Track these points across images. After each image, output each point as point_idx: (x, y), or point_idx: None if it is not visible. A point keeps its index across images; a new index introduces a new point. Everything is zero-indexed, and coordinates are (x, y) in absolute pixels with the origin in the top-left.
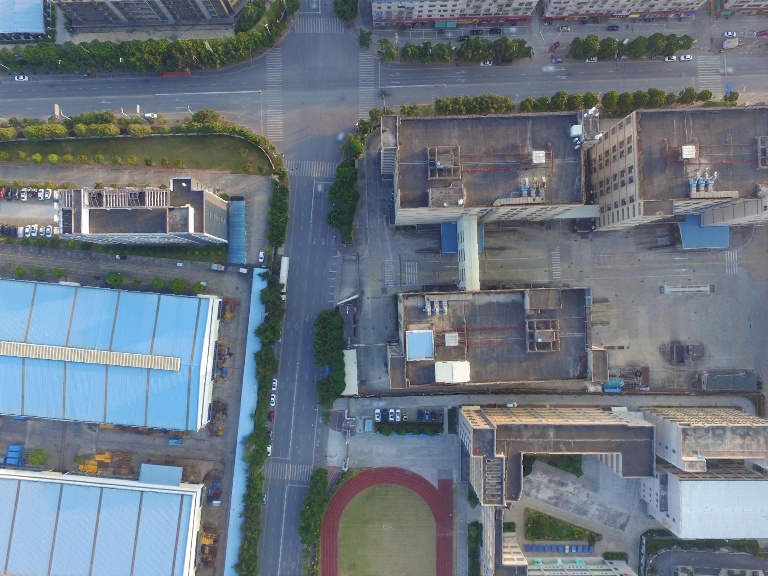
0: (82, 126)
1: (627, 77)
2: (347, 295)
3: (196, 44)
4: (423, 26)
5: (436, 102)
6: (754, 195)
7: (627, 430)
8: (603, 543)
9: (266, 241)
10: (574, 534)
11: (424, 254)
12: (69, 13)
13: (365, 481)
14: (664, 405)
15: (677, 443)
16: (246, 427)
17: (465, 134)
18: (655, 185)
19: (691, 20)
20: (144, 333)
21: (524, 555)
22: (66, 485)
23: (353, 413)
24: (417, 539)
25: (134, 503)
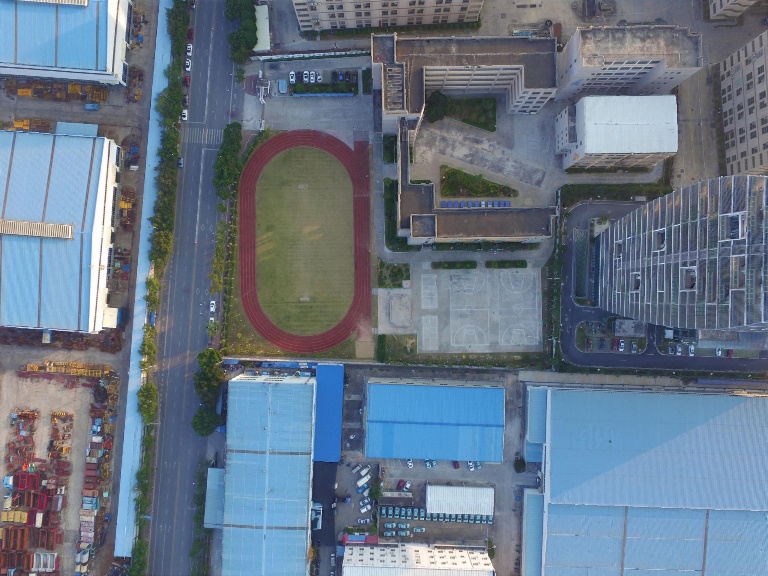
0: None
1: None
2: None
3: None
4: None
5: None
6: None
7: (529, 44)
8: (519, 199)
9: None
10: (490, 189)
11: None
12: None
13: (281, 144)
14: None
15: (577, 47)
16: (160, 85)
17: None
18: None
19: None
20: None
21: None
22: None
23: (268, 77)
24: (334, 200)
25: (47, 146)
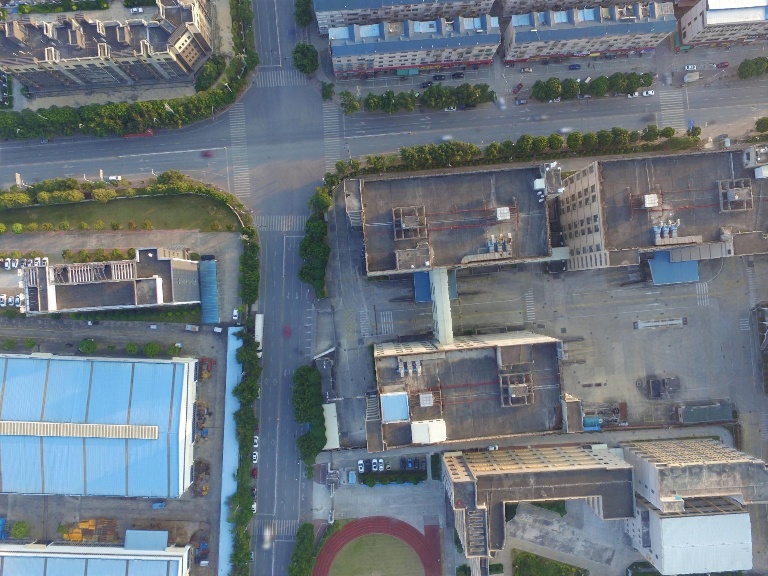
0: (45, 194)
1: (591, 115)
2: (324, 348)
3: (156, 106)
4: (385, 74)
5: (402, 152)
6: (718, 238)
7: (606, 473)
8: None
9: (239, 298)
10: (561, 572)
11: (398, 303)
12: (24, 81)
13: (352, 532)
14: (643, 439)
15: (655, 484)
16: (229, 487)
17: (429, 193)
18: (620, 234)
19: (651, 55)
20: (120, 403)
21: None
22: (50, 559)
23: (336, 465)
24: None
25: (120, 572)
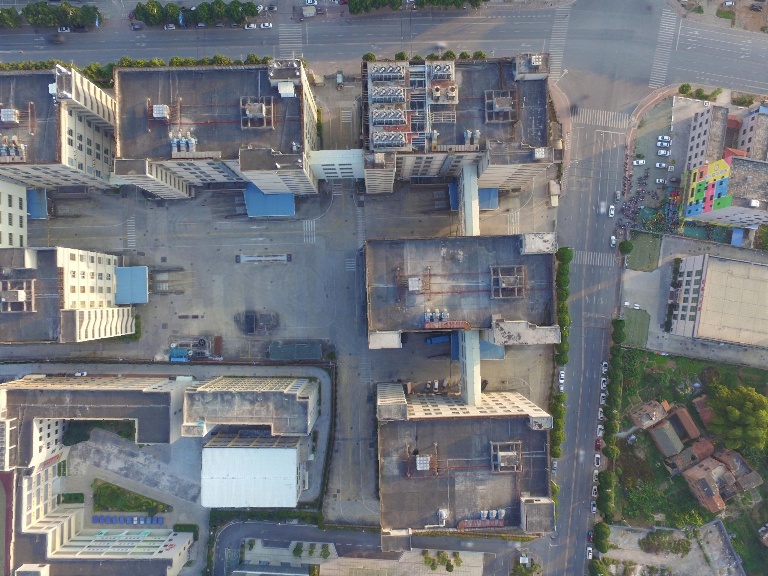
0: None
1: (207, 45)
2: None
3: None
4: None
5: None
6: None
7: (145, 396)
8: (174, 515)
9: None
10: (142, 505)
11: None
12: None
13: None
14: (237, 375)
15: None
16: None
17: None
18: (139, 145)
19: None
20: None
21: (93, 527)
22: None
23: None
24: None
25: None
